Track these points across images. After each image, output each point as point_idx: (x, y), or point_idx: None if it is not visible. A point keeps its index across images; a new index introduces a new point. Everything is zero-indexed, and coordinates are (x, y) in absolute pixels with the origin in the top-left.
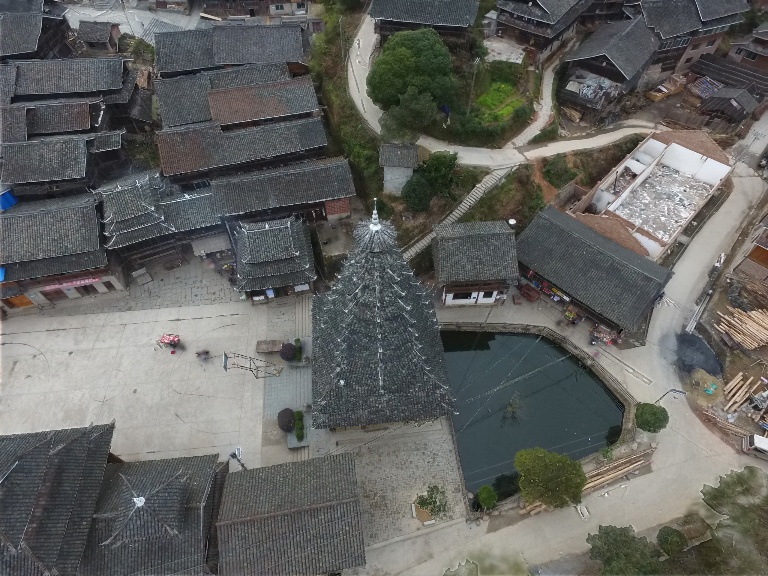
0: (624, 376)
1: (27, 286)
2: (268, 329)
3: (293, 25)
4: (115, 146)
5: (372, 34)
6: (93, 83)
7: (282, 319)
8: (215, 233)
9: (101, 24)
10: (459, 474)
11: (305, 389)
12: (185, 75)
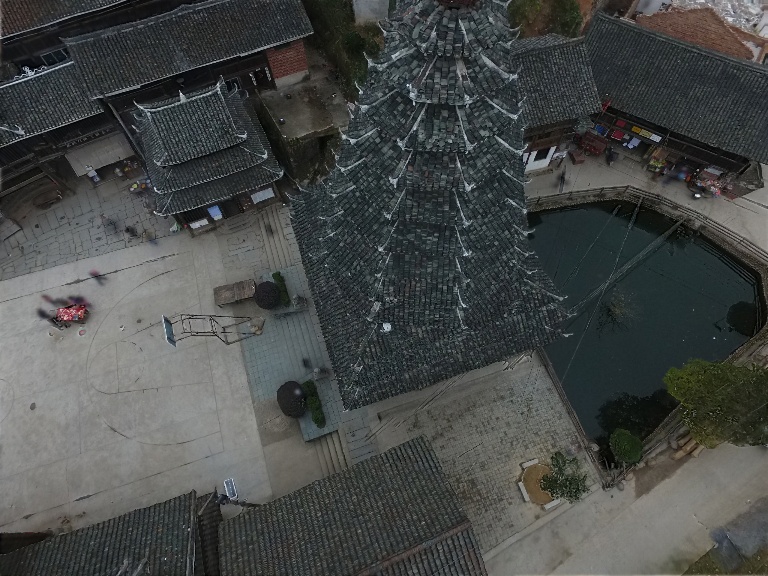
0: (749, 233)
1: None
2: (226, 267)
3: None
4: None
5: None
6: None
7: (244, 249)
8: (101, 134)
9: None
10: (572, 421)
11: (307, 345)
12: None
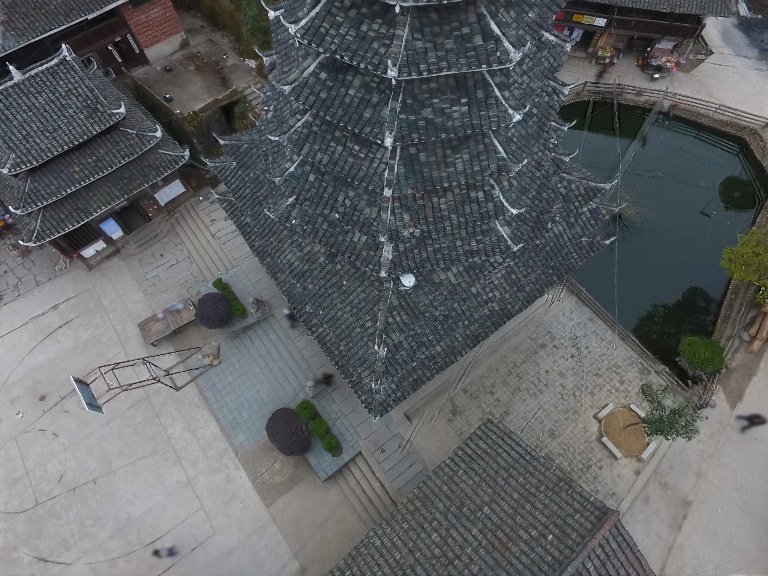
0: (719, 100)
1: None
2: (147, 295)
3: None
4: None
5: None
6: None
7: (164, 265)
8: None
9: None
10: (630, 346)
11: (286, 358)
12: None
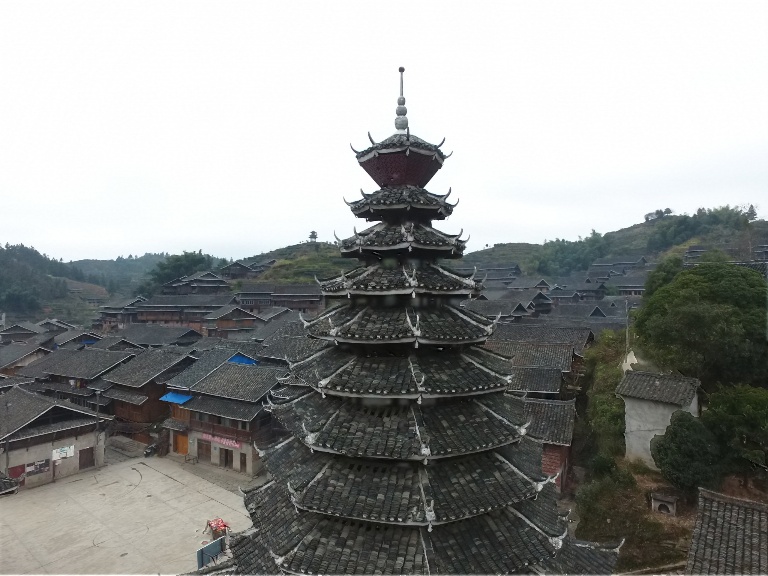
0: None
1: (193, 425)
2: None
3: (582, 328)
4: None
5: None
6: None
7: None
8: None
9: None
10: None
11: None
12: None
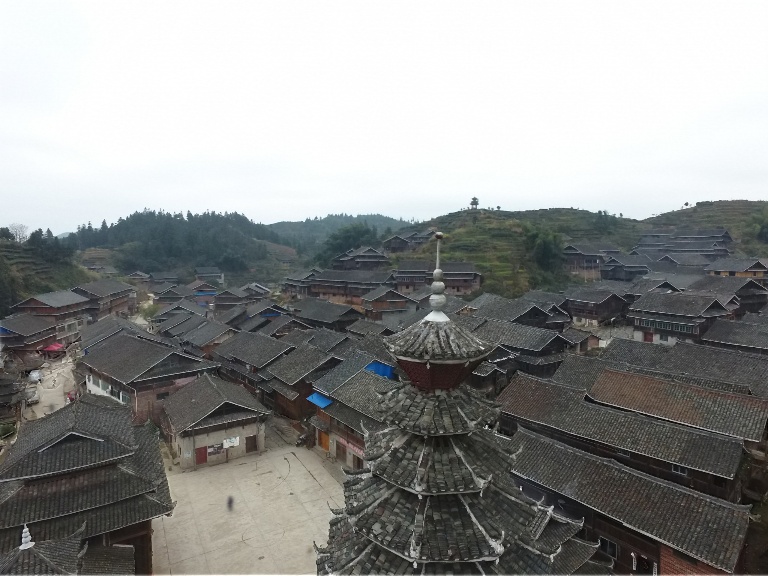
0: None
1: (333, 428)
2: None
3: None
4: (482, 373)
5: None
6: (521, 342)
7: None
8: None
9: (584, 332)
10: None
11: None
12: None
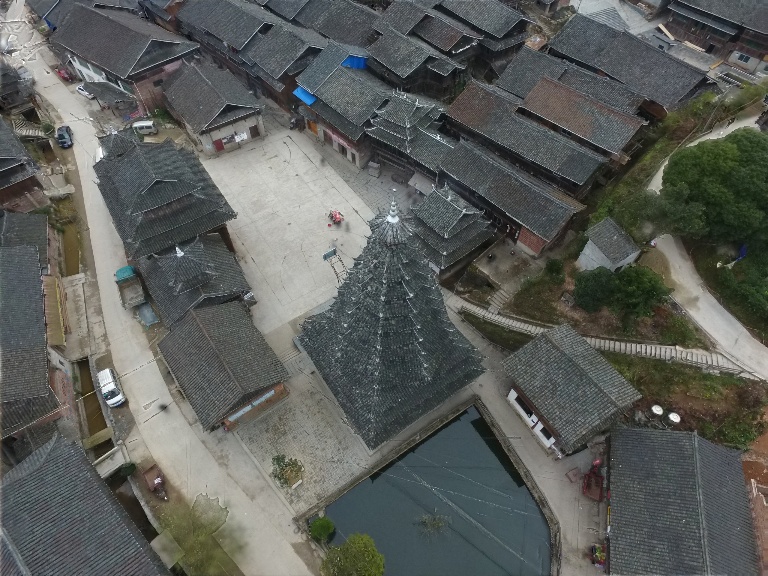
0: None
1: (319, 120)
2: None
3: (698, 71)
4: (443, 72)
5: (752, 121)
6: (488, 23)
7: None
8: None
9: None
10: None
11: None
12: (550, 55)
